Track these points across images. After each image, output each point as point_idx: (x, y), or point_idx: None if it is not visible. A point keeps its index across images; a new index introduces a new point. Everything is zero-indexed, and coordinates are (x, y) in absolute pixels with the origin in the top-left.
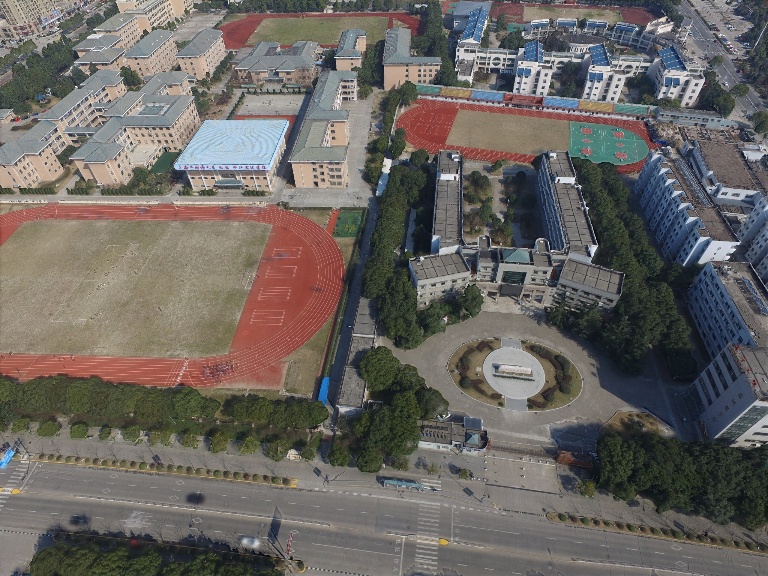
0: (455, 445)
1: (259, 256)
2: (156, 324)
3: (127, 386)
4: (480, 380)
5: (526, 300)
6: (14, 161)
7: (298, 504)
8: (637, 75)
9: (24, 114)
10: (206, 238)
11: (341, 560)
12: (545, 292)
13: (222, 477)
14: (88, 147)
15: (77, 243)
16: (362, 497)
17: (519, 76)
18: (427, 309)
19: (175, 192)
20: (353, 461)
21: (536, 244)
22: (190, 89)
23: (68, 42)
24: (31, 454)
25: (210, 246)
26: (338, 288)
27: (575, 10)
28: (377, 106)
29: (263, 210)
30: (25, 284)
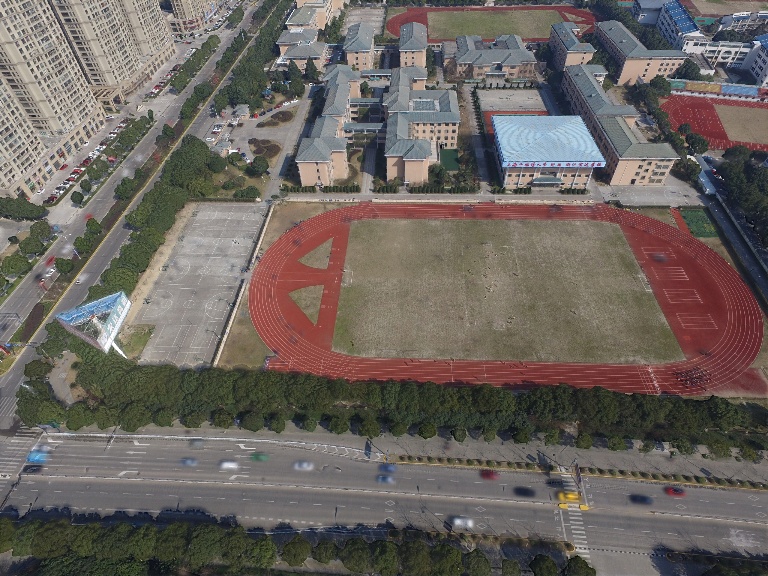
0: None
1: (632, 257)
2: (583, 328)
3: (645, 395)
4: None
5: None
6: (329, 158)
7: None
8: None
9: (257, 110)
10: (560, 238)
11: None
12: None
13: None
14: (403, 144)
15: (426, 243)
16: None
17: None
18: None
19: (485, 190)
20: None
21: None
22: None
23: (246, 36)
24: (567, 467)
25: (571, 246)
26: (746, 290)
27: (747, 3)
28: (624, 101)
29: (595, 209)
30: (407, 286)
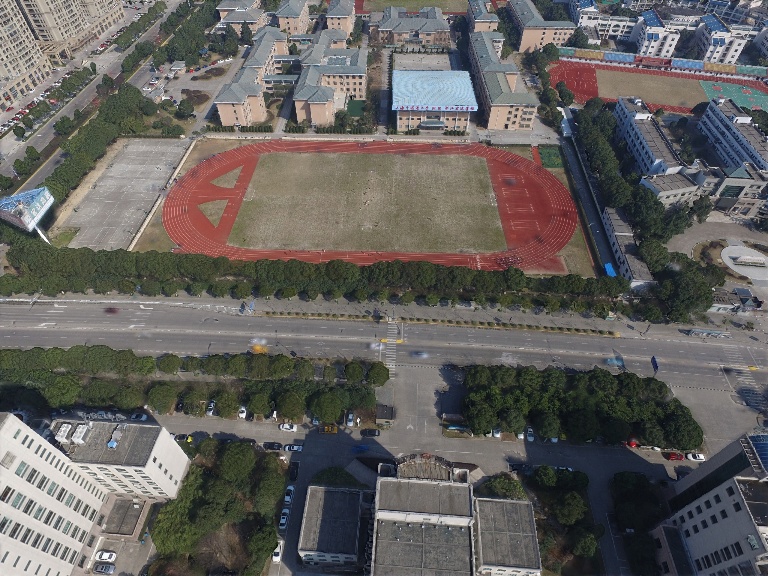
0: (733, 307)
1: (489, 181)
2: (434, 230)
3: (459, 266)
4: (726, 267)
5: (733, 213)
6: (244, 100)
7: (628, 347)
8: (746, 42)
9: (193, 66)
10: (434, 167)
11: (682, 380)
12: (754, 204)
13: (558, 331)
14: (308, 89)
15: (321, 170)
16: (675, 342)
17: (648, 40)
18: (674, 213)
19: (381, 132)
20: (655, 320)
21: (745, 166)
22: (346, 46)
23: (193, 4)
24: None
25: (441, 173)
26: (571, 204)
27: None
28: (520, 65)
29: (470, 146)
30: (298, 201)
